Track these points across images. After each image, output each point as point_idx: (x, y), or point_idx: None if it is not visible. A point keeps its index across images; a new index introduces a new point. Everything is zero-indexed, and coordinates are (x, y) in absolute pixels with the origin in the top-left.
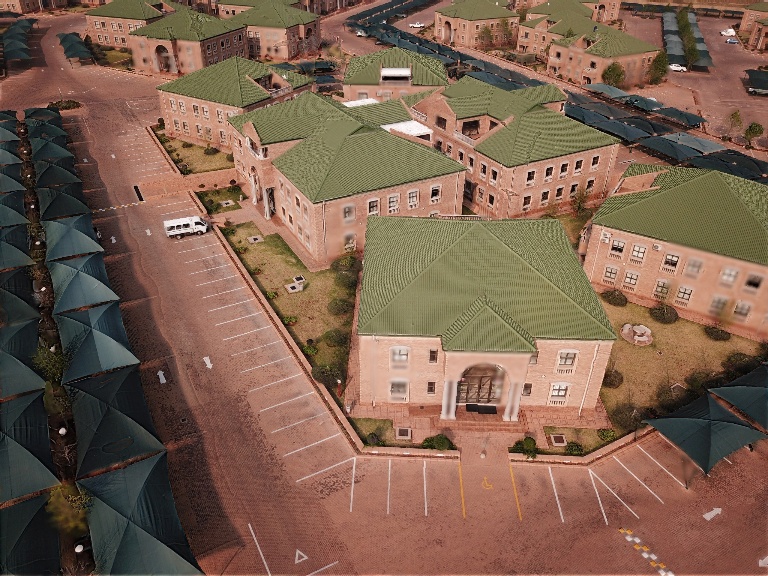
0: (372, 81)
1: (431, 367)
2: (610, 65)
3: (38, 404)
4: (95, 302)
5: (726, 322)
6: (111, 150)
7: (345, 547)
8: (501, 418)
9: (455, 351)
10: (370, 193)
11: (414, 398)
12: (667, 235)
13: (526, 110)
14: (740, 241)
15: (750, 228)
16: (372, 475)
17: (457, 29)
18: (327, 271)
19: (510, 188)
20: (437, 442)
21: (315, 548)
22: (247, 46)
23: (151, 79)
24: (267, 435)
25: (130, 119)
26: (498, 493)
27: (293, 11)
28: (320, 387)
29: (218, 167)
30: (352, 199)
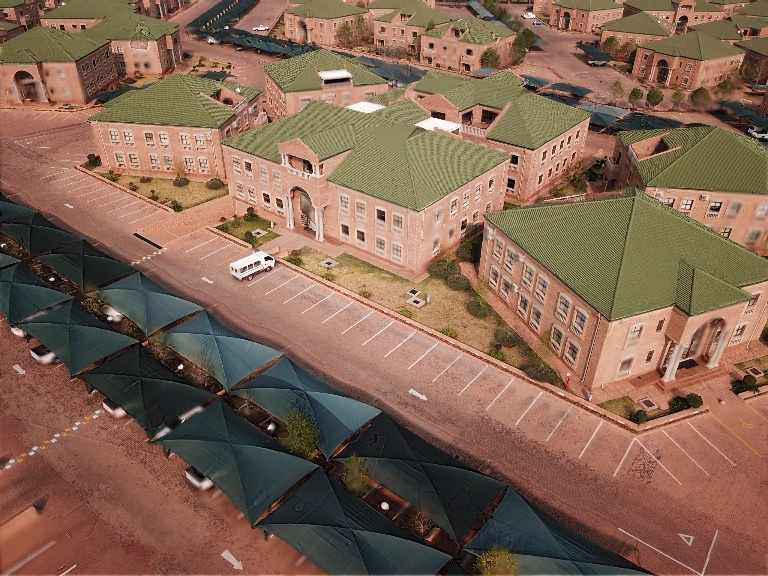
0: (314, 86)
1: (655, 337)
2: (485, 51)
3: (338, 487)
4: (260, 365)
5: (759, 249)
6: (58, 199)
7: (710, 516)
8: (706, 367)
9: (699, 314)
10: (453, 193)
11: (634, 371)
12: (712, 185)
13: (517, 96)
14: (767, 180)
15: (767, 169)
16: (663, 448)
17: (313, 29)
18: (431, 279)
19: (532, 169)
20: (694, 401)
21: (690, 526)
22: (114, 63)
23: (19, 112)
24: (546, 444)
25: (42, 161)
26: (761, 428)
27: (151, 21)
28: (547, 386)
29: (206, 197)
30: (441, 201)
